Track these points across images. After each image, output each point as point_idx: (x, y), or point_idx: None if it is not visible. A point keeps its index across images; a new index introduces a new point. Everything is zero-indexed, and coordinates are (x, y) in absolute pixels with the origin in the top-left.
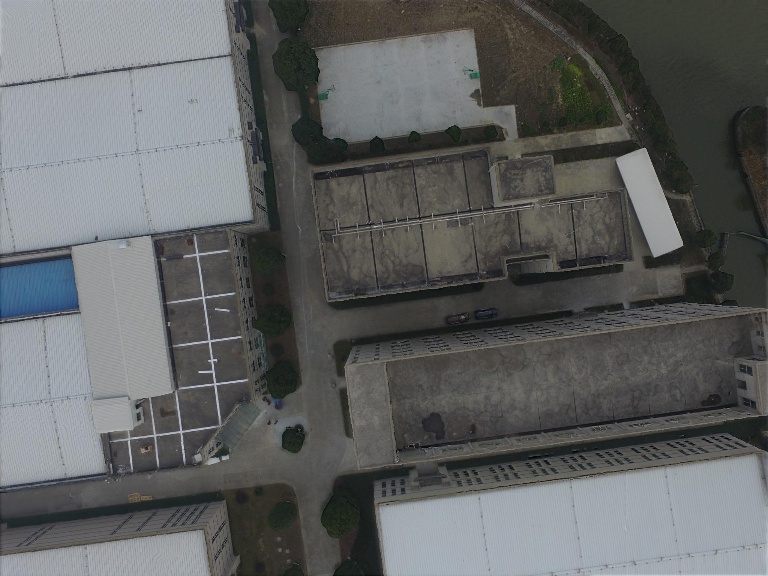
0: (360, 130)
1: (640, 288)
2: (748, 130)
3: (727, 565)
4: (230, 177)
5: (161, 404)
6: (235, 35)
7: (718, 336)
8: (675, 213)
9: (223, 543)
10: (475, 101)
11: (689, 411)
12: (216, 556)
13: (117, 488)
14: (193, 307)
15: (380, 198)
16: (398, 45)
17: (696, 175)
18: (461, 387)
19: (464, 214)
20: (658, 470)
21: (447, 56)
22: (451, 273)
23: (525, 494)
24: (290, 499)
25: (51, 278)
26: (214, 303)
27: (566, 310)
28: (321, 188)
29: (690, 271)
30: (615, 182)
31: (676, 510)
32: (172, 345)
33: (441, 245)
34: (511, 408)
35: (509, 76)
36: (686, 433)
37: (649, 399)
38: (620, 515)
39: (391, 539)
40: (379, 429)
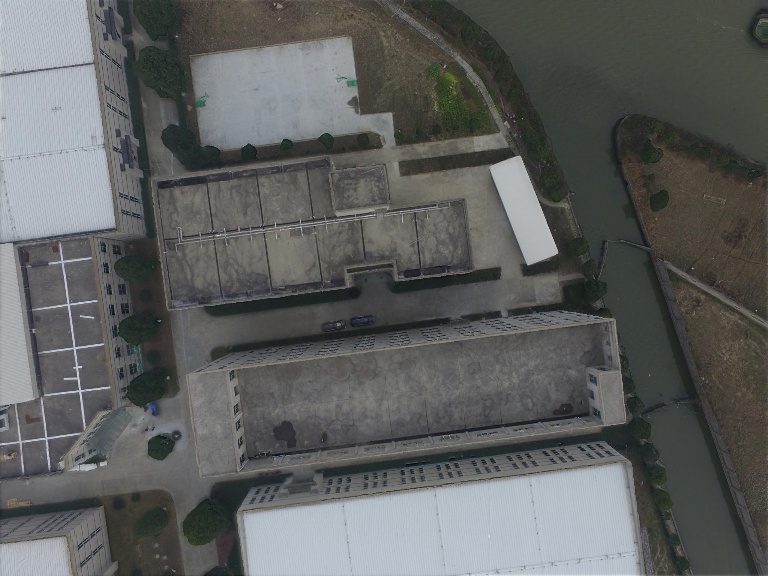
0: (238, 137)
1: (518, 296)
2: (627, 138)
3: (591, 574)
4: (93, 185)
5: (26, 411)
6: (103, 43)
7: (570, 345)
8: (552, 221)
9: (96, 549)
10: (352, 108)
11: (540, 420)
12: (83, 562)
13: None
14: (58, 314)
15: (224, 207)
16: (276, 52)
17: (575, 183)
18: (312, 395)
19: (306, 223)
20: (523, 478)
21: (325, 63)
22: (295, 282)
23: (391, 502)
24: (167, 505)
25: None
26: (79, 310)
27: (444, 317)
28: (165, 197)
29: (568, 279)
30: (492, 190)
31: (540, 519)
32: (37, 352)
33: (285, 254)
34: (362, 417)
35: (385, 84)
36: (563, 441)
37: (501, 408)
38: (484, 523)
39: (255, 546)
40: (221, 438)
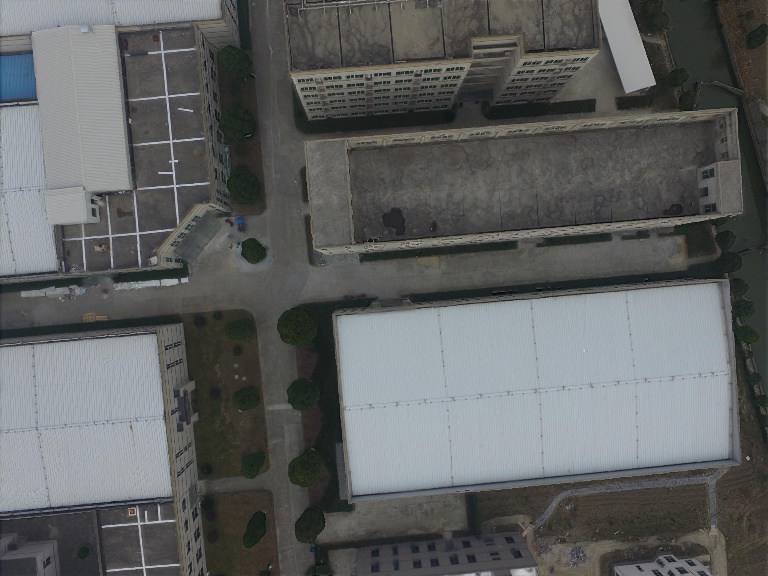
0: None
1: None
2: None
3: (683, 392)
4: None
5: (118, 204)
6: None
7: (683, 145)
8: (649, 55)
9: (177, 361)
10: None
11: None
12: (168, 366)
13: (71, 307)
14: (156, 106)
15: None
16: None
17: (672, 21)
18: (423, 183)
19: None
20: (619, 295)
21: None
22: (417, 56)
23: (485, 316)
24: None
25: (10, 72)
26: (177, 102)
27: None
28: None
29: None
30: None
31: (635, 335)
32: (132, 144)
33: (408, 26)
34: (473, 207)
35: None
36: (650, 276)
37: (611, 205)
38: (579, 338)
39: (348, 352)
40: (337, 209)
